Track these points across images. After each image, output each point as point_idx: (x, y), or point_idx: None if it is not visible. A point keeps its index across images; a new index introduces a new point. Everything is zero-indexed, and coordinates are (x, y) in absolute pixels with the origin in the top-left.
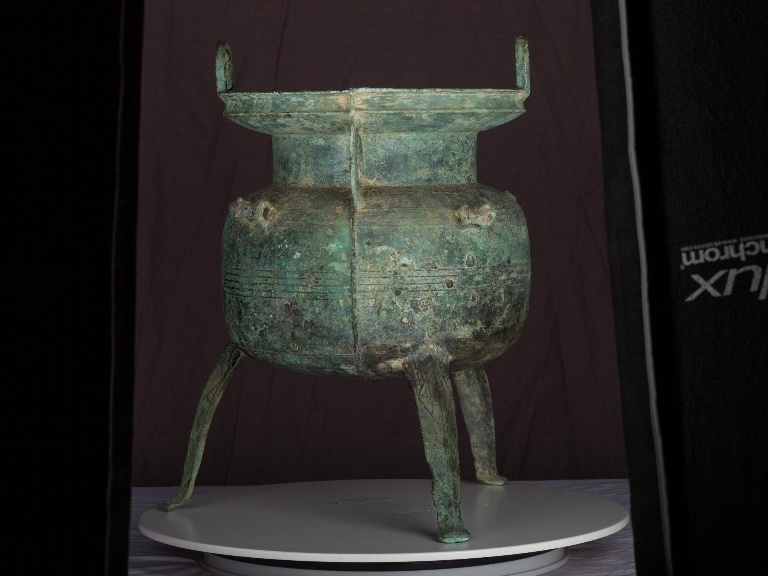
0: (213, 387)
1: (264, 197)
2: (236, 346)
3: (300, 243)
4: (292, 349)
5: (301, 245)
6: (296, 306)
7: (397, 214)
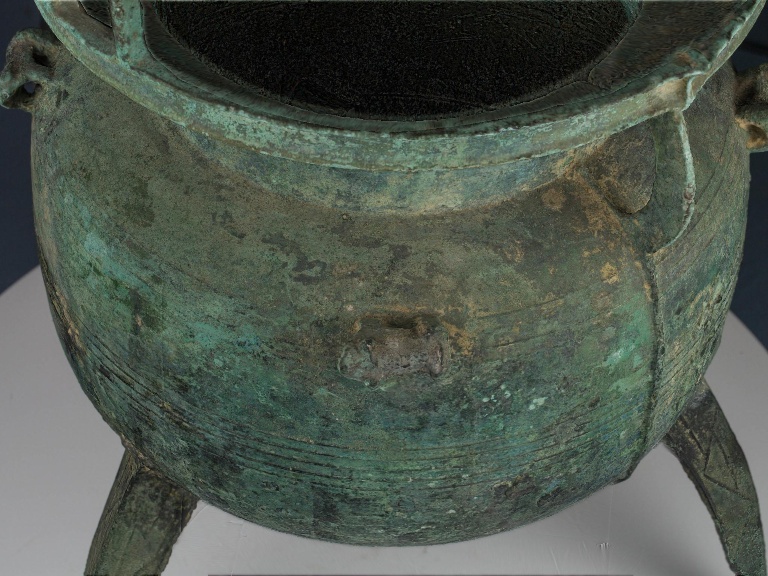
0: (134, 574)
1: (357, 279)
2: (173, 486)
3: (544, 380)
4: (485, 535)
5: (547, 383)
6: (529, 483)
7: (705, 216)
